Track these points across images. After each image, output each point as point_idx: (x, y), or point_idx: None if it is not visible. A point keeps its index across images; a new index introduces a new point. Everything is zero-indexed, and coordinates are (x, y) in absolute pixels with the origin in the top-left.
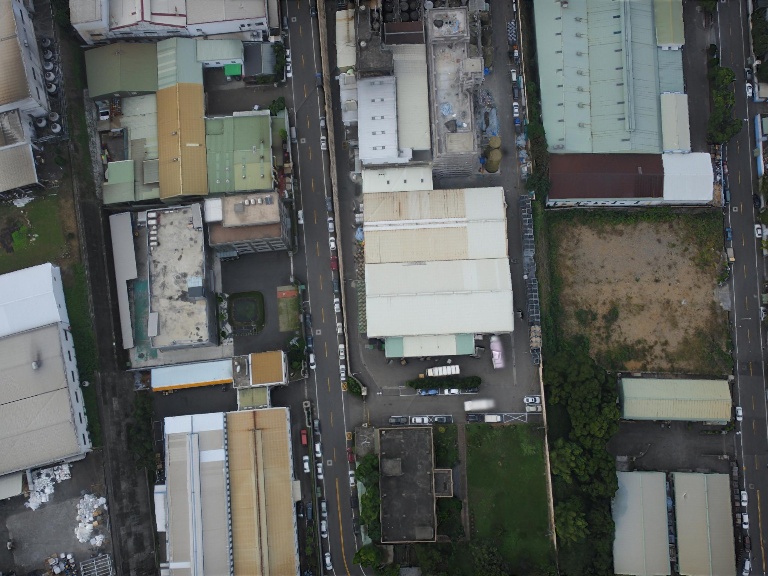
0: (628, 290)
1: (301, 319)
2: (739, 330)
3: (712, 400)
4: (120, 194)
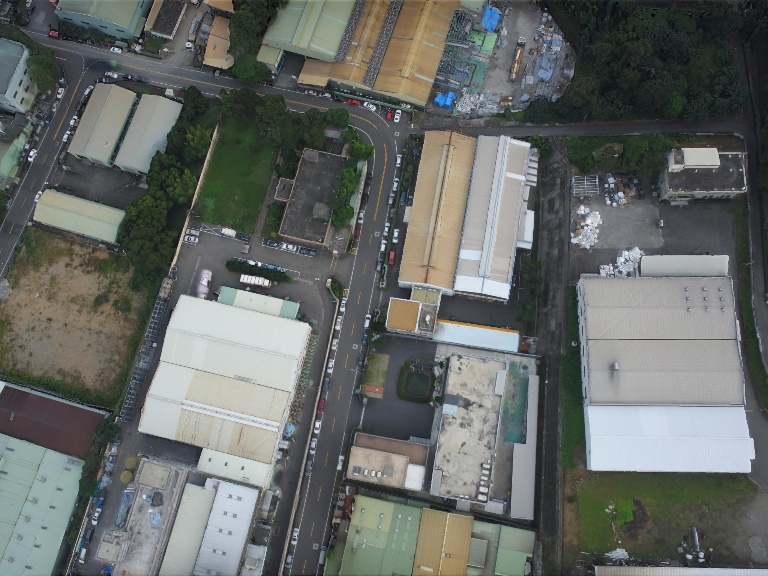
0: (77, 319)
1: (366, 360)
2: (5, 261)
3: (52, 206)
4: (516, 538)
